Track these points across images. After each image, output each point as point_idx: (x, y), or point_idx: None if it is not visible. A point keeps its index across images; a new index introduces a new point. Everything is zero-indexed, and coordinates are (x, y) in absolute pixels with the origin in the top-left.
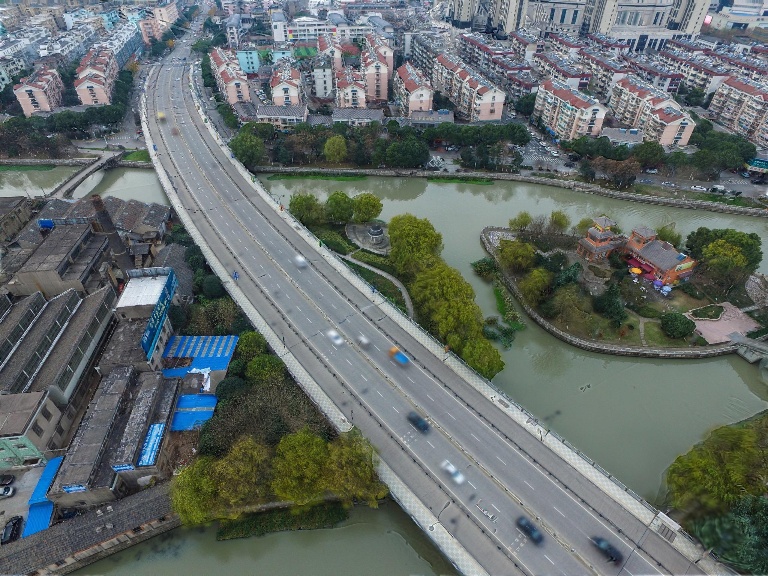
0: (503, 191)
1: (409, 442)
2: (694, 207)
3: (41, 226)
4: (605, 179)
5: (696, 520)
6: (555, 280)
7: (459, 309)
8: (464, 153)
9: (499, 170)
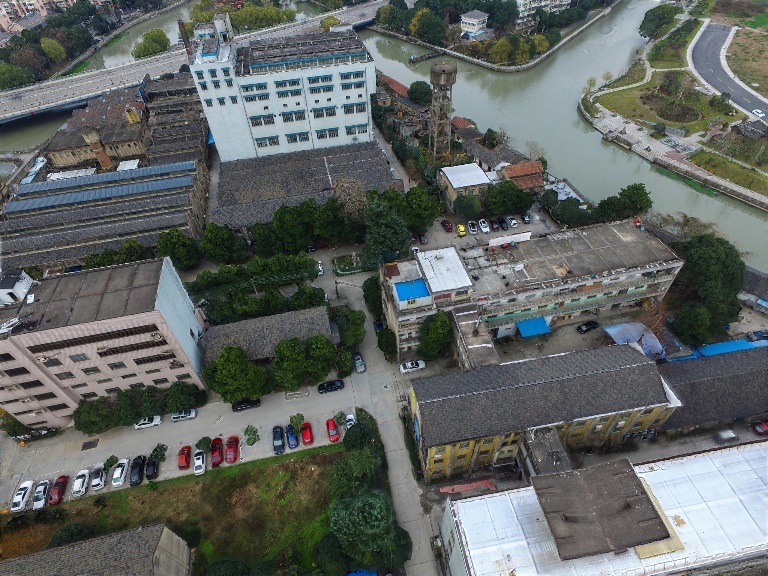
0: (126, 42)
1: (321, 28)
2: (188, 1)
3: (143, 93)
4: (151, 8)
5: (345, 3)
6: (252, 2)
7: (269, 8)
8: (97, 23)
9: (116, 27)
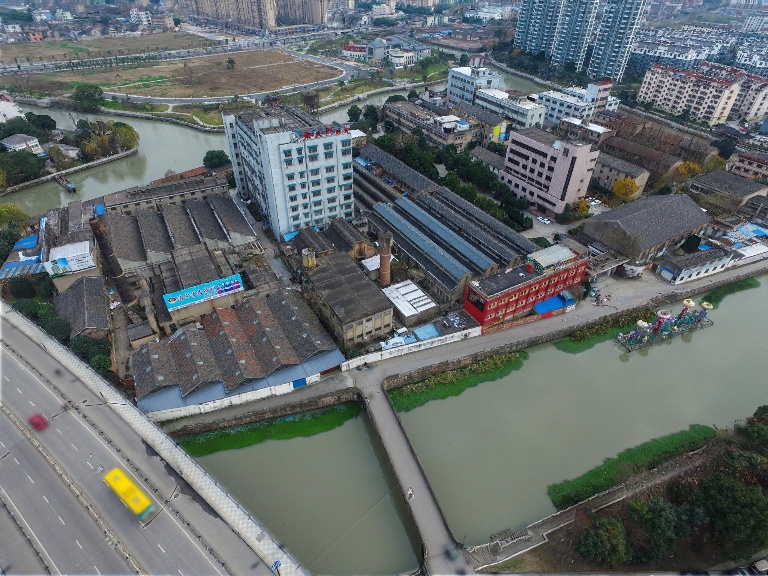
0: None
1: None
2: None
3: None
4: None
5: None
6: None
7: None
8: None
9: None
